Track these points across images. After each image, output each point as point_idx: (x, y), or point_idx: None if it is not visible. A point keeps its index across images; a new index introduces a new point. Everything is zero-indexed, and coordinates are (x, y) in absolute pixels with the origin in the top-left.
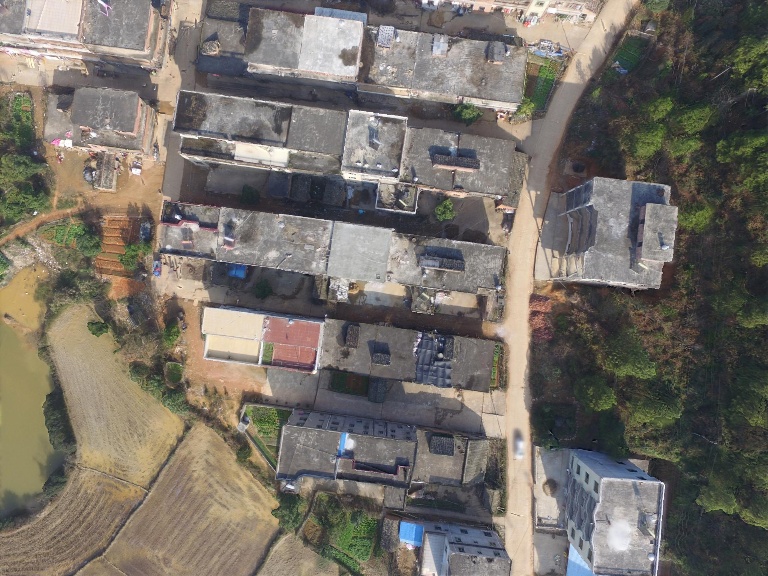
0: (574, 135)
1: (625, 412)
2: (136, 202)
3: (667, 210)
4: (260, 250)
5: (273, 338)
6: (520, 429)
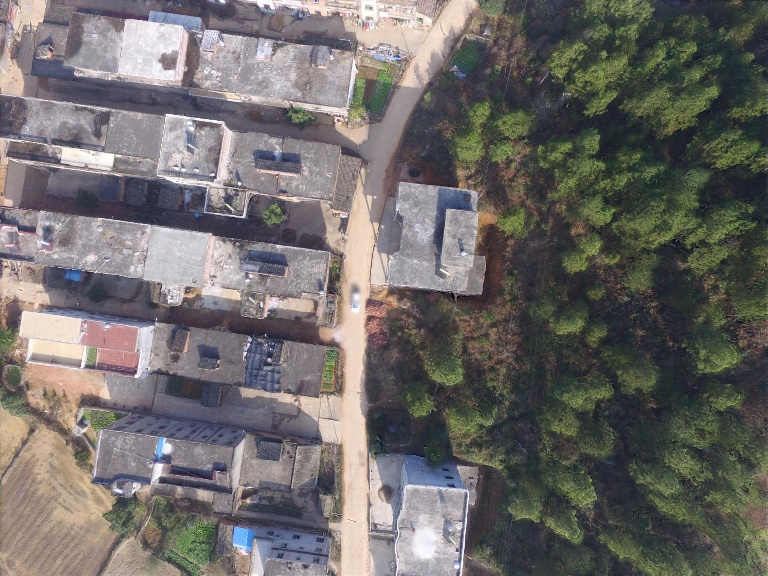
0: (410, 139)
1: None
2: None
3: (467, 216)
4: (78, 254)
5: (90, 342)
6: (356, 434)
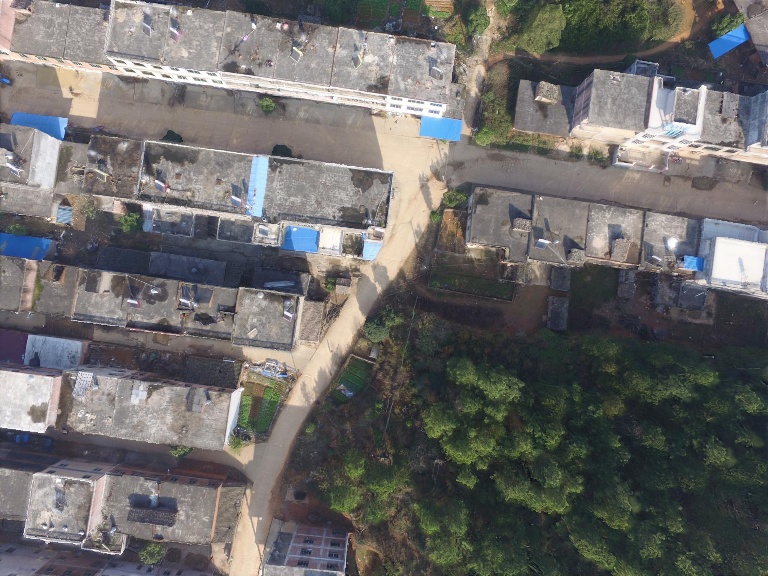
0: (296, 461)
1: None
2: None
3: None
4: None
5: None
6: None
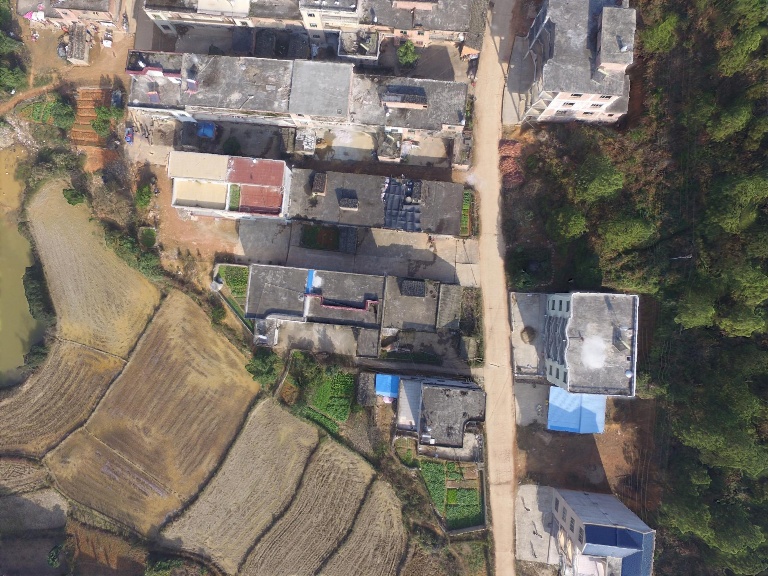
0: None
1: (599, 243)
2: (108, 74)
3: (624, 13)
4: (223, 93)
5: (238, 178)
6: (495, 277)
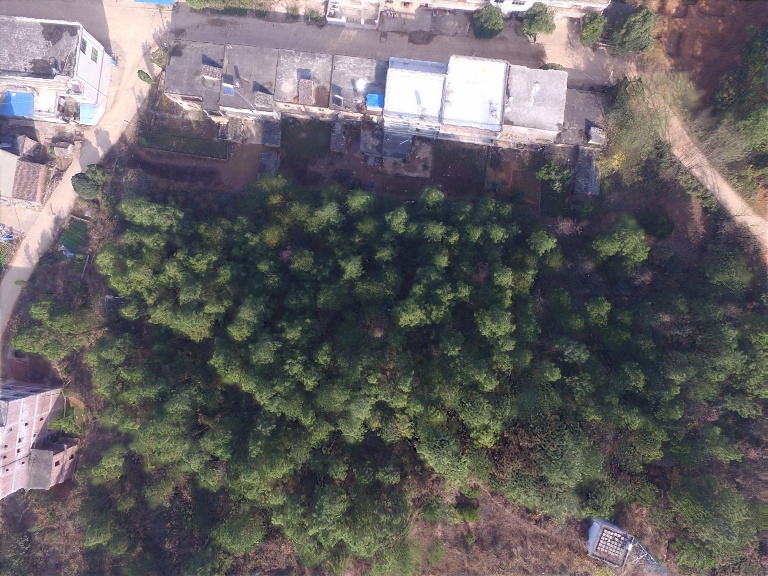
0: None
1: None
2: None
3: None
4: None
5: None
6: None
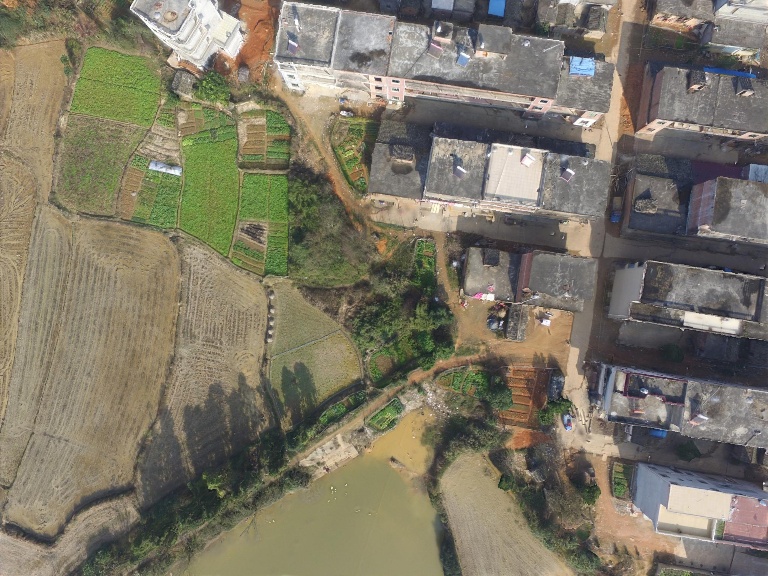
0: None
1: None
2: (542, 352)
3: None
4: (727, 426)
5: (742, 518)
6: None
